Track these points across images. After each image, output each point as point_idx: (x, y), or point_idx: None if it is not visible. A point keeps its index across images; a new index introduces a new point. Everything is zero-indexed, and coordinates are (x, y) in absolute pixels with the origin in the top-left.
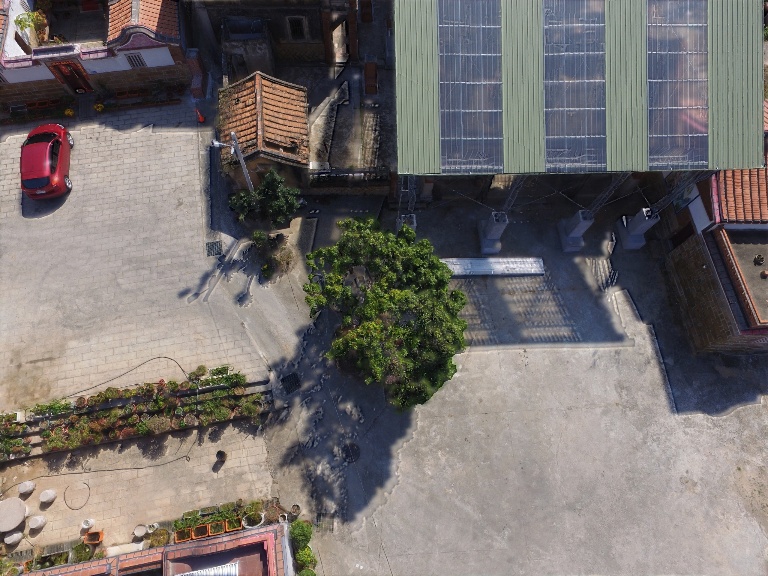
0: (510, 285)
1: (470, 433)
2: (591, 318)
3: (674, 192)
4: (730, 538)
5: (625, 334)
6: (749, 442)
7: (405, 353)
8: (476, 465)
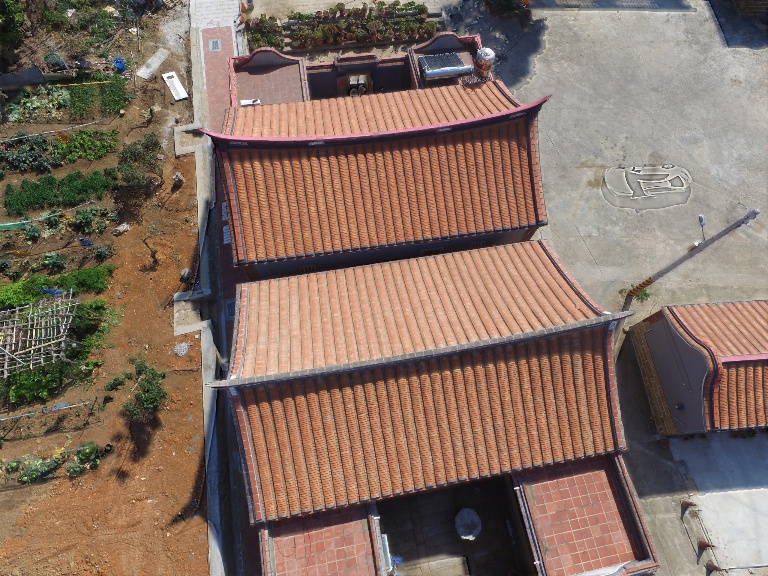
0: None
1: (583, 52)
2: None
3: None
4: (766, 109)
5: (689, 5)
6: None
7: None
8: (589, 68)
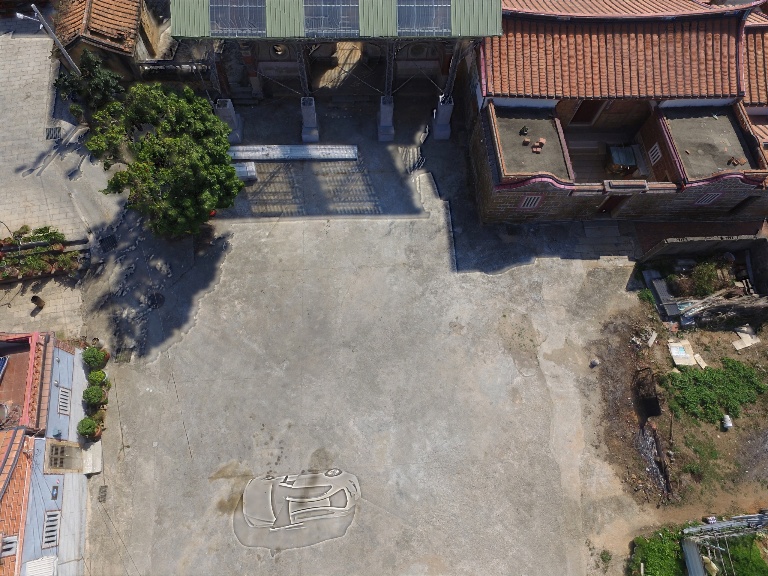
0: (325, 168)
1: (267, 286)
2: (394, 195)
3: (450, 71)
4: (485, 370)
5: (422, 208)
6: (517, 295)
7: (162, 182)
8: (267, 311)
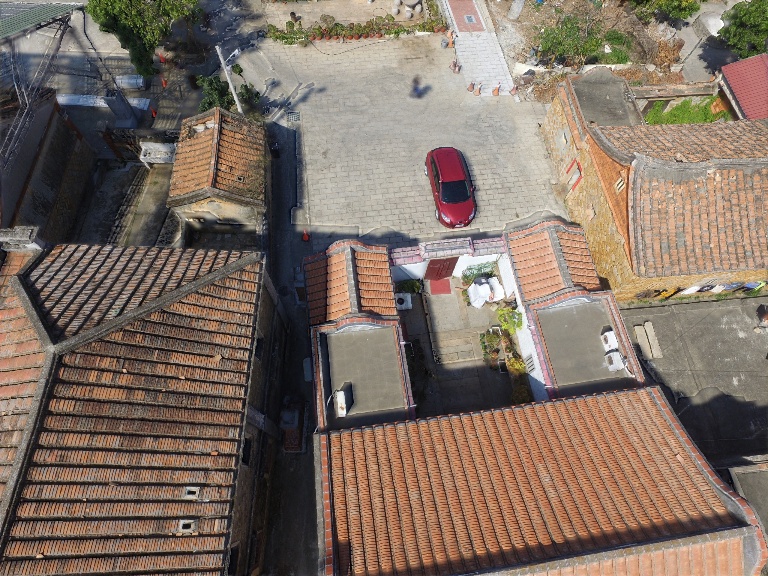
0: None
1: None
2: None
3: None
4: None
5: None
6: None
7: None
8: None
